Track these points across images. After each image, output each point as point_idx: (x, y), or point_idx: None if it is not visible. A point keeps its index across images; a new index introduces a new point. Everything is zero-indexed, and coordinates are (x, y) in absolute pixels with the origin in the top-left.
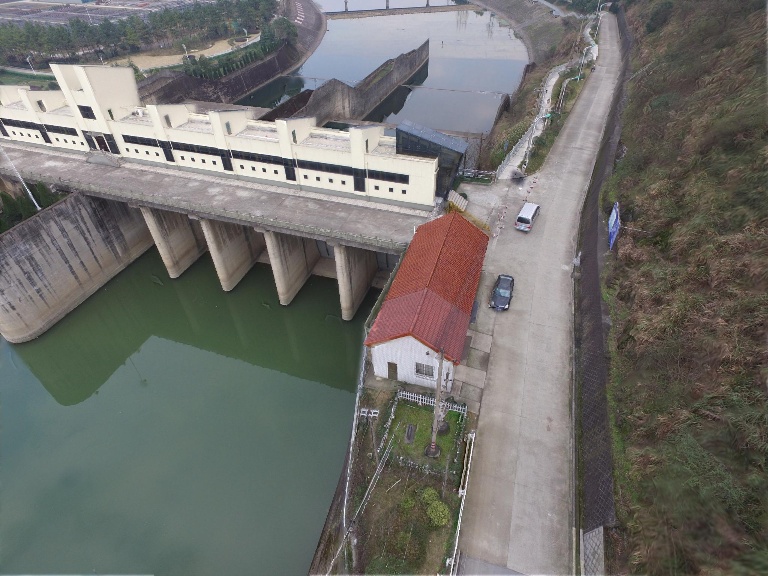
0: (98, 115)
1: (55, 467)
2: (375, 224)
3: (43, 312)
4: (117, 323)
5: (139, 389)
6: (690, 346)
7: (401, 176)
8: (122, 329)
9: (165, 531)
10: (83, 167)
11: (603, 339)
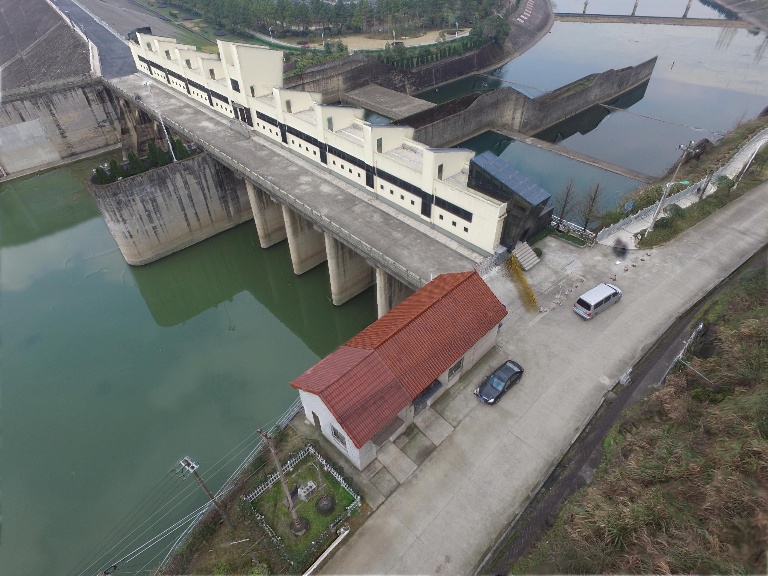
0: (242, 90)
1: (98, 375)
2: (422, 255)
3: (154, 246)
4: (216, 271)
5: (186, 336)
6: (609, 575)
7: (465, 212)
8: (219, 278)
9: (132, 468)
10: (224, 132)
11: (562, 496)
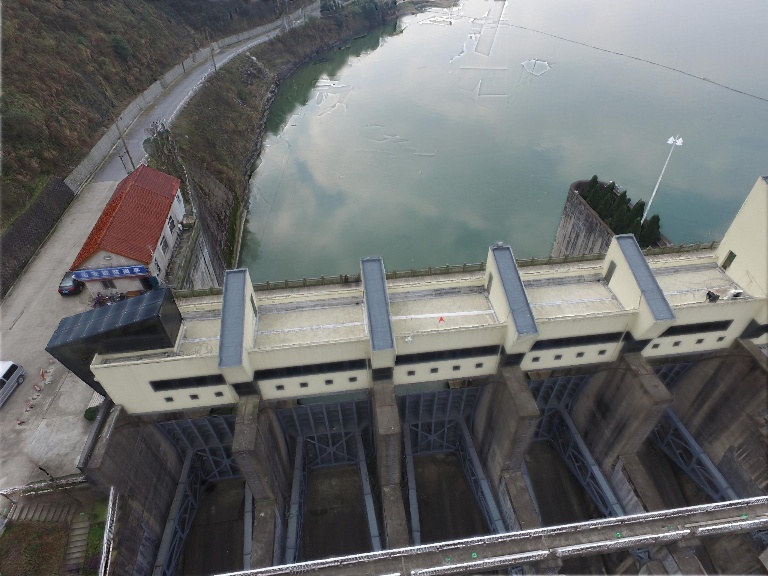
0: None
1: (418, 237)
2: None
3: None
4: None
5: None
6: None
7: None
8: None
9: (326, 238)
10: None
11: (7, 234)
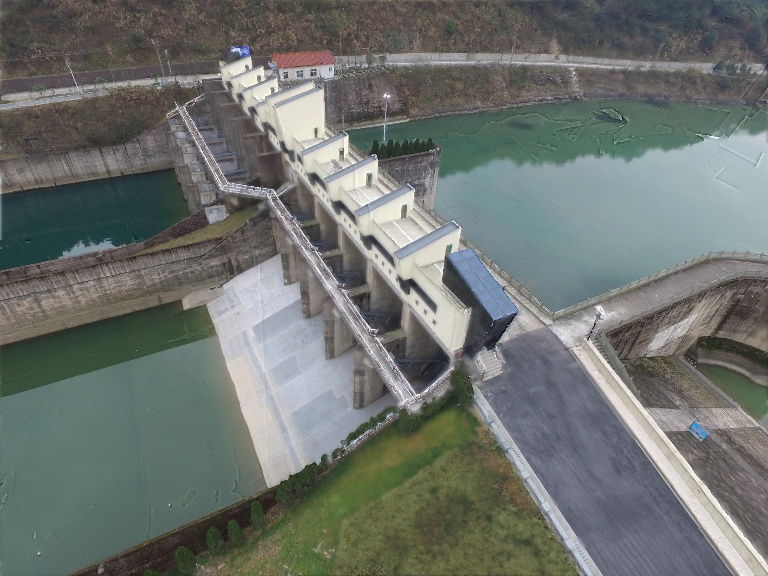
0: None
1: None
2: None
3: None
4: None
5: None
6: None
7: None
8: None
9: None
10: None
11: None
